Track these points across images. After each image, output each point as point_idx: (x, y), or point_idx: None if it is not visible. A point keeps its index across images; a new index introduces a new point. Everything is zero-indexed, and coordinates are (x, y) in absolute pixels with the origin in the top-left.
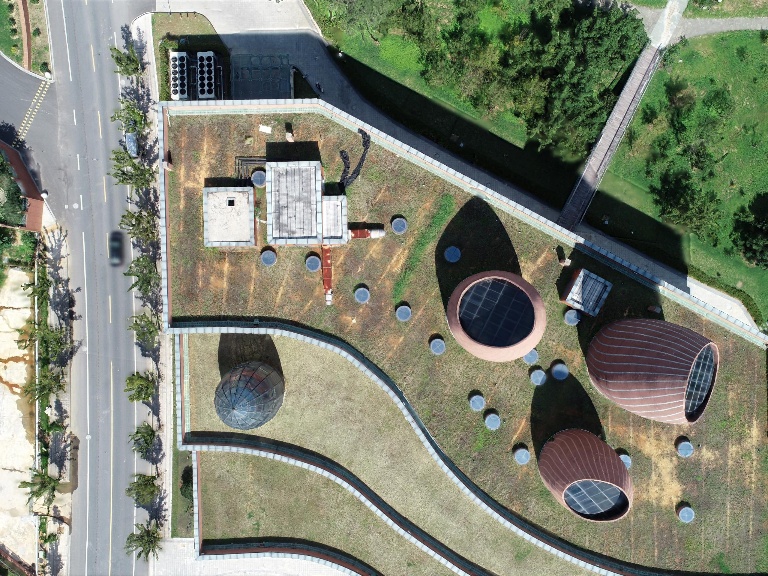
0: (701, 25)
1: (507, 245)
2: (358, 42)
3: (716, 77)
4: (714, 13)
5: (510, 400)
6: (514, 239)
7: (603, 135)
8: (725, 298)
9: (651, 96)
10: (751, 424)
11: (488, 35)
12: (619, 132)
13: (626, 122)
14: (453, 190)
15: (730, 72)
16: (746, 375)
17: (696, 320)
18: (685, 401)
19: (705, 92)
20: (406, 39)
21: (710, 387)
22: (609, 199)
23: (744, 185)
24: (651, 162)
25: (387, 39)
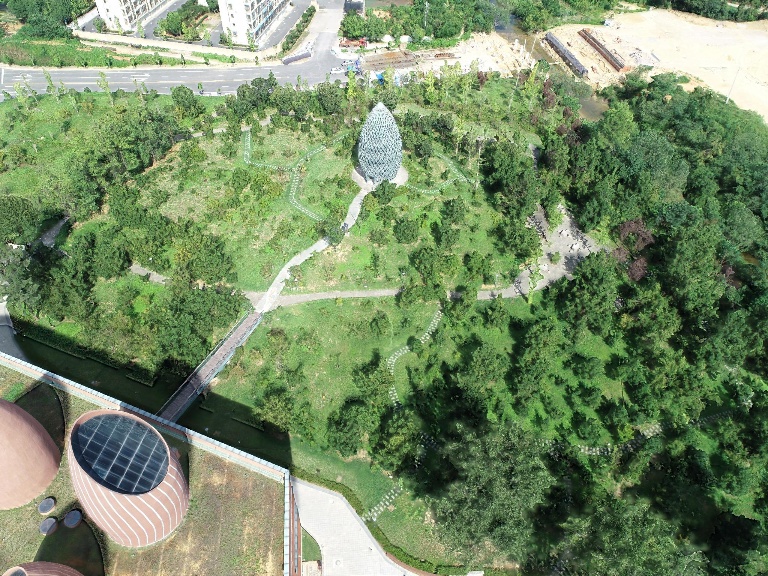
0: (293, 298)
1: (59, 416)
2: (39, 329)
3: (306, 327)
4: (302, 291)
5: (13, 555)
6: (66, 411)
7: (206, 364)
8: (327, 493)
9: (257, 342)
10: (266, 558)
11: (139, 317)
12: (221, 362)
13: (228, 356)
14: (26, 380)
15: (316, 323)
16: (264, 509)
17: (219, 463)
18: (109, 472)
19: (297, 336)
20: (77, 324)
21: (163, 478)
22: (220, 417)
23: (334, 396)
24: (256, 386)
25: (62, 325)
